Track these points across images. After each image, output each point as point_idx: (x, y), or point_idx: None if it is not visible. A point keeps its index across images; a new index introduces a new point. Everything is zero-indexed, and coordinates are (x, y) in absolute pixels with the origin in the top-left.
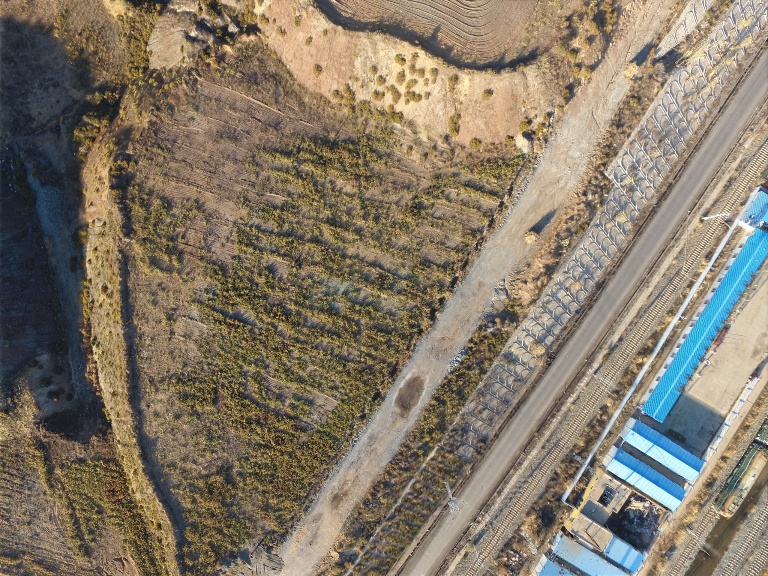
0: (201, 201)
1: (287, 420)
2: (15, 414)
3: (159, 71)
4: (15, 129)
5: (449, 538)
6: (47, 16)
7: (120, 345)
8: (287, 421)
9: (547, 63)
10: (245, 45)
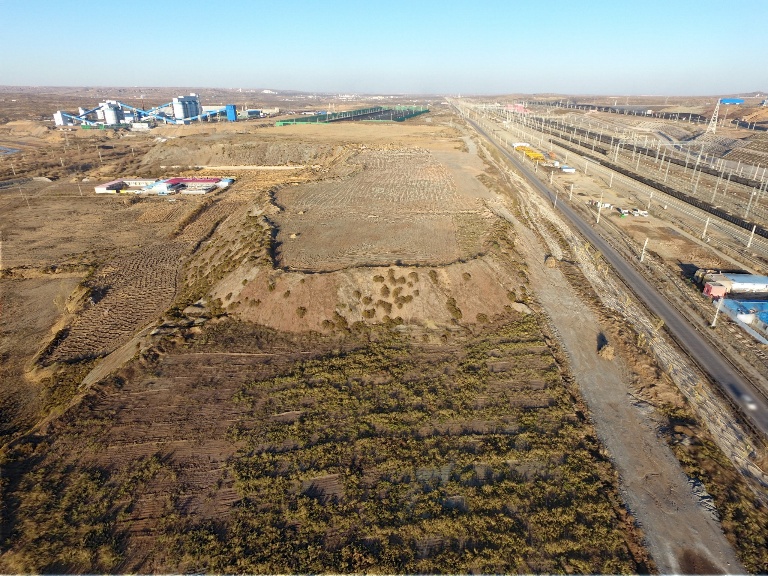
0: (165, 453)
1: None
2: None
3: None
4: None
5: None
6: None
7: None
8: None
9: (494, 254)
10: (215, 326)
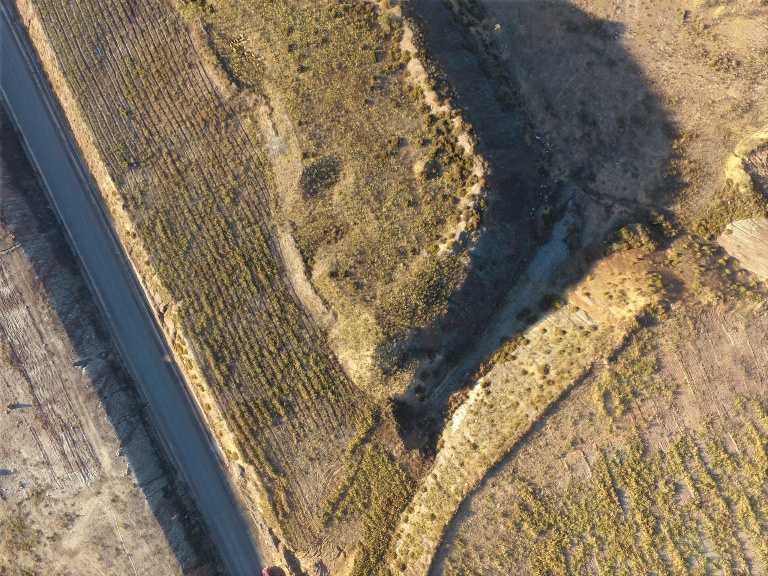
0: (681, 390)
1: None
2: (386, 379)
3: (732, 259)
4: (575, 174)
5: None
6: (680, 125)
7: (523, 426)
8: None
9: None
10: None
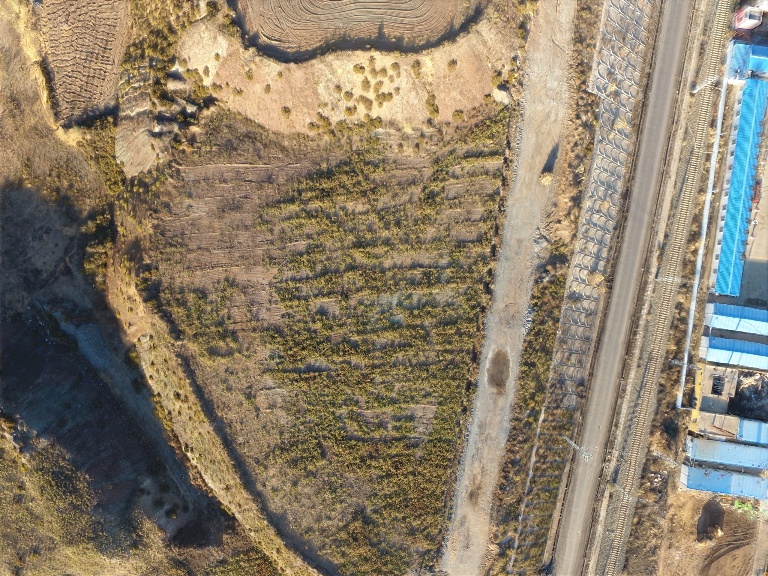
0: (231, 278)
1: (397, 443)
2: (145, 546)
3: (138, 177)
4: (28, 287)
5: (588, 487)
6: (13, 172)
7: (215, 441)
8: (397, 444)
9: (495, 13)
10: (209, 118)
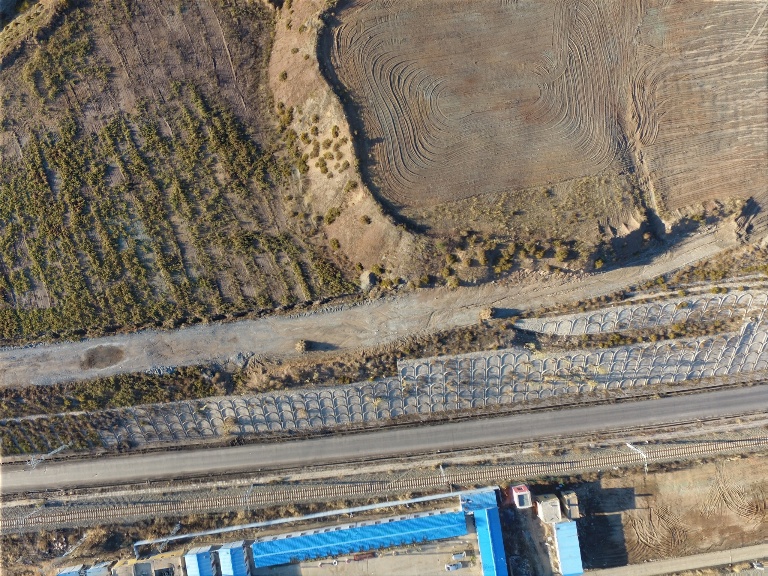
0: (116, 73)
1: (3, 280)
2: None
3: None
4: None
5: (35, 482)
6: None
7: None
8: (2, 281)
9: (424, 244)
10: (262, 6)
